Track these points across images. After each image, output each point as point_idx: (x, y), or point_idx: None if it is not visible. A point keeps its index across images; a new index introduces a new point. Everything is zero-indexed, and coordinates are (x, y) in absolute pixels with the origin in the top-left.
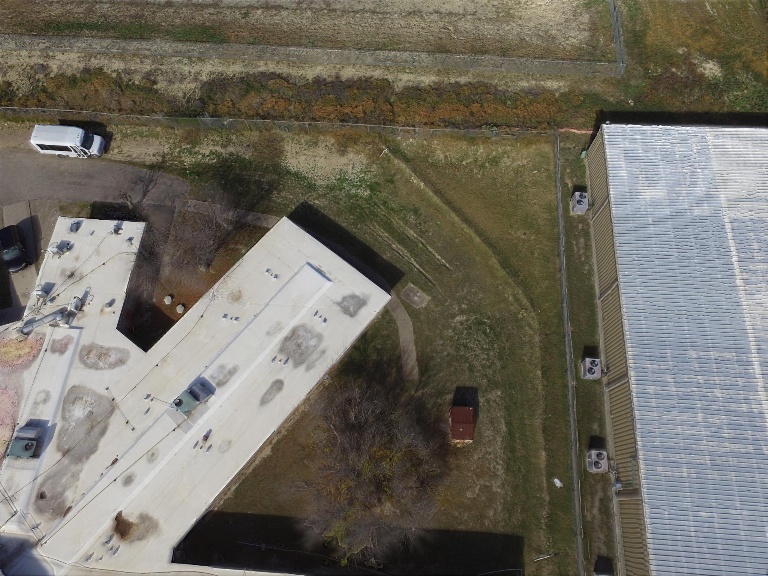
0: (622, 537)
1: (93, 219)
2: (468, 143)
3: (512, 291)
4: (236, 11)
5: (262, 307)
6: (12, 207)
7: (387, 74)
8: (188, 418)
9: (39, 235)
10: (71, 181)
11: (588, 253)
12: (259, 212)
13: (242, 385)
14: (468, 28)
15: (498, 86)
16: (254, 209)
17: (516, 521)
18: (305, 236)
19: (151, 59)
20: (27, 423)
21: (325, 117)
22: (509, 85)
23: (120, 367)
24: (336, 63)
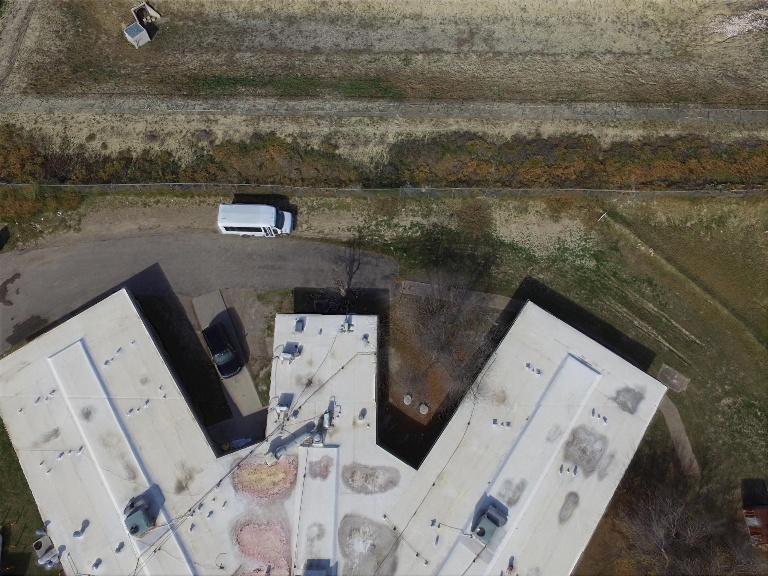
0: None
1: (316, 315)
2: (692, 203)
3: None
4: (394, 57)
5: (533, 409)
6: (202, 299)
7: (591, 129)
8: (486, 546)
9: (242, 331)
10: (263, 265)
11: None
12: (482, 291)
13: (534, 502)
14: (652, 70)
15: (710, 138)
16: (475, 288)
17: None
18: (558, 323)
19: (328, 120)
20: (306, 565)
21: (534, 180)
22: (722, 136)
23: (392, 489)
24: (533, 118)
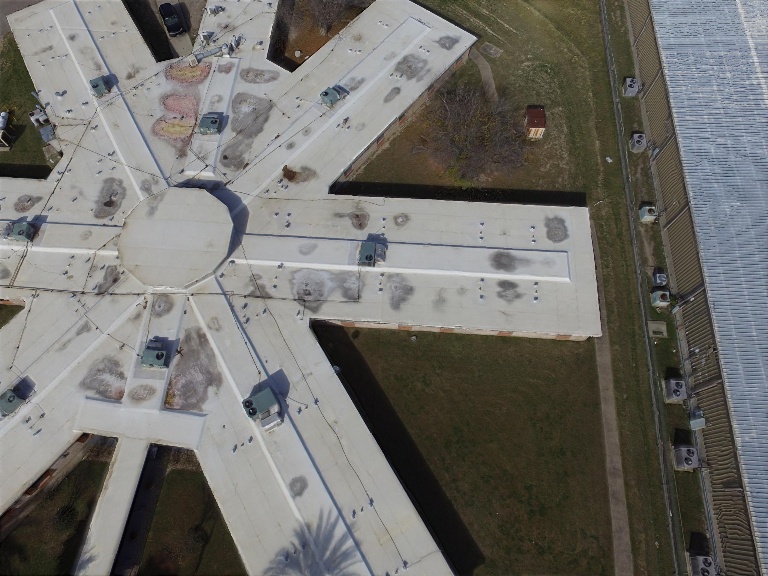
0: (659, 182)
1: None
2: None
3: (566, 45)
4: None
5: (378, 44)
6: None
7: None
8: (331, 109)
9: (188, 15)
10: None
11: (623, 20)
12: None
13: (369, 91)
14: None
15: None
16: None
17: (579, 184)
18: (406, 1)
19: None
20: None
21: None
22: None
23: (273, 82)
24: None
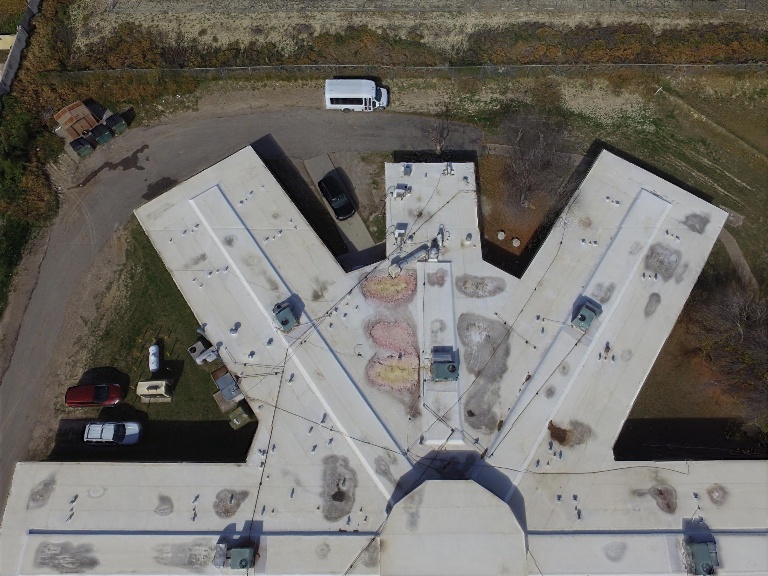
0: None
1: (420, 163)
2: (736, 78)
3: None
4: None
5: (615, 231)
6: (313, 161)
7: (644, 19)
8: (586, 333)
9: (350, 185)
10: (363, 133)
11: None
12: (558, 151)
13: (622, 301)
14: None
15: (749, 25)
16: (552, 149)
17: None
18: (630, 165)
19: (413, 15)
20: (433, 350)
21: (598, 61)
22: (758, 24)
23: (500, 294)
24: (593, 11)
